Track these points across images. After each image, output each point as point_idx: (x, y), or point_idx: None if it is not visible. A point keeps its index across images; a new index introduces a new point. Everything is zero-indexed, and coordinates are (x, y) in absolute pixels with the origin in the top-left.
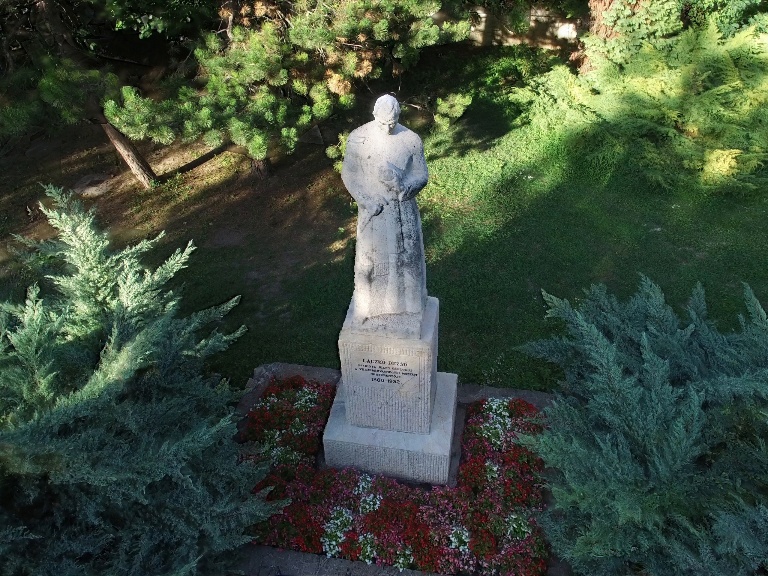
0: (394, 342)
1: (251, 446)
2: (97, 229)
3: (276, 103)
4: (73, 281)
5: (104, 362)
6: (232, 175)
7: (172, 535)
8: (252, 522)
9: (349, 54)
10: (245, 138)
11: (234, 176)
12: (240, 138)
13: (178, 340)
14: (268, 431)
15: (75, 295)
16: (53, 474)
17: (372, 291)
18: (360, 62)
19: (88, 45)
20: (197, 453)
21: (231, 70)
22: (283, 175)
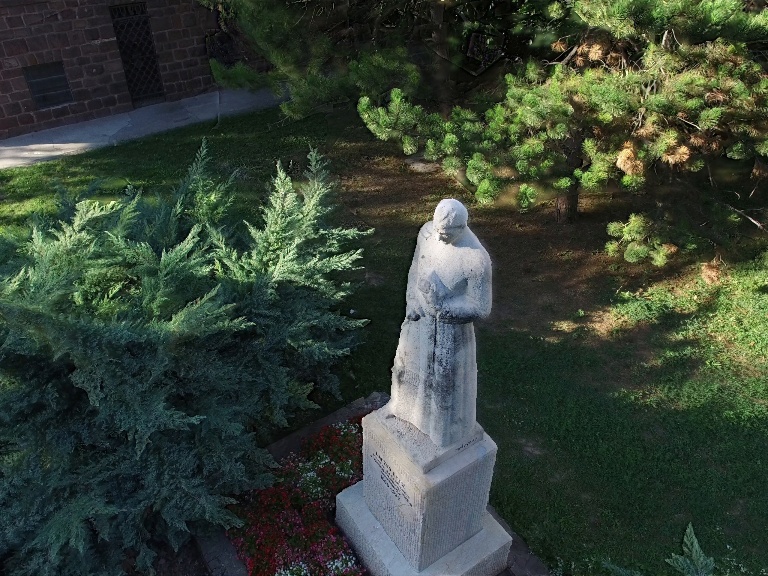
0: (401, 457)
1: (263, 454)
2: (328, 201)
3: (544, 155)
4: (259, 234)
5: (184, 311)
6: (536, 205)
7: (144, 477)
8: (204, 516)
9: (670, 132)
10: (477, 177)
11: (537, 207)
12: (473, 175)
13: (293, 327)
14: (322, 452)
15: (257, 246)
16: (77, 371)
17: (400, 392)
18: (678, 146)
19: (486, 38)
20: (203, 428)
21: (522, 105)
22: (581, 228)
